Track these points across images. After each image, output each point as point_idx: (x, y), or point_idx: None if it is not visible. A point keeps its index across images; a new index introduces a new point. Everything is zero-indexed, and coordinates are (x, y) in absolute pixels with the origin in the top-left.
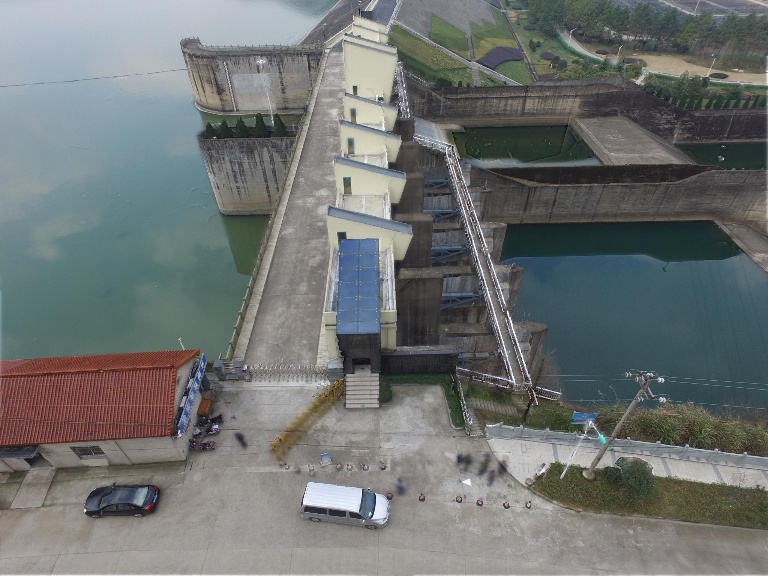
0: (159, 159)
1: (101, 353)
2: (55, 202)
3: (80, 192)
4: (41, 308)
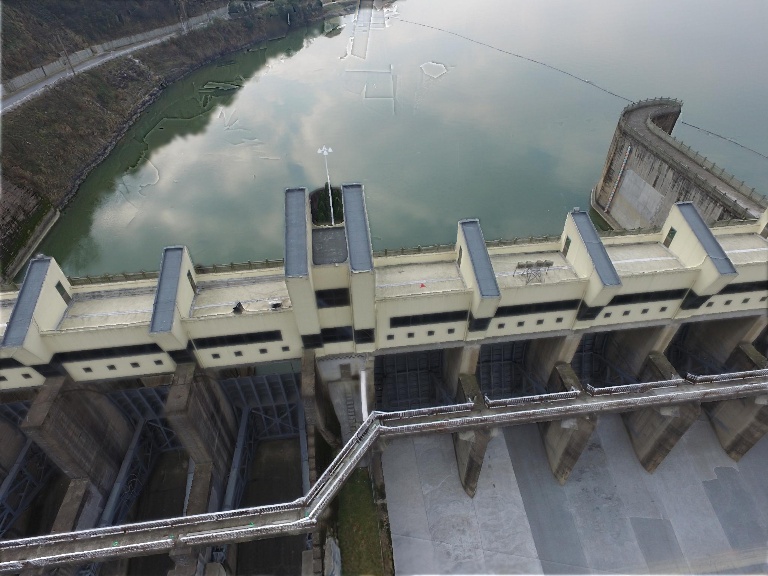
0: (451, 196)
1: (119, 264)
2: (351, 170)
3: (371, 176)
4: (194, 218)
